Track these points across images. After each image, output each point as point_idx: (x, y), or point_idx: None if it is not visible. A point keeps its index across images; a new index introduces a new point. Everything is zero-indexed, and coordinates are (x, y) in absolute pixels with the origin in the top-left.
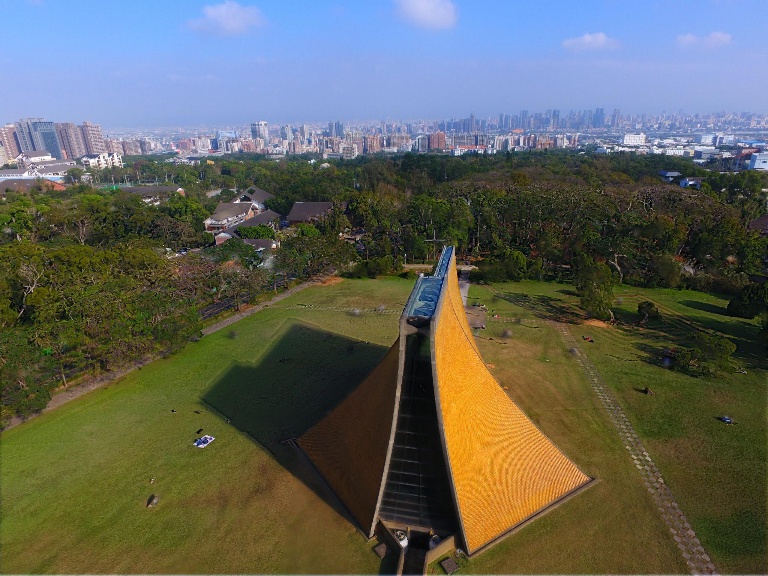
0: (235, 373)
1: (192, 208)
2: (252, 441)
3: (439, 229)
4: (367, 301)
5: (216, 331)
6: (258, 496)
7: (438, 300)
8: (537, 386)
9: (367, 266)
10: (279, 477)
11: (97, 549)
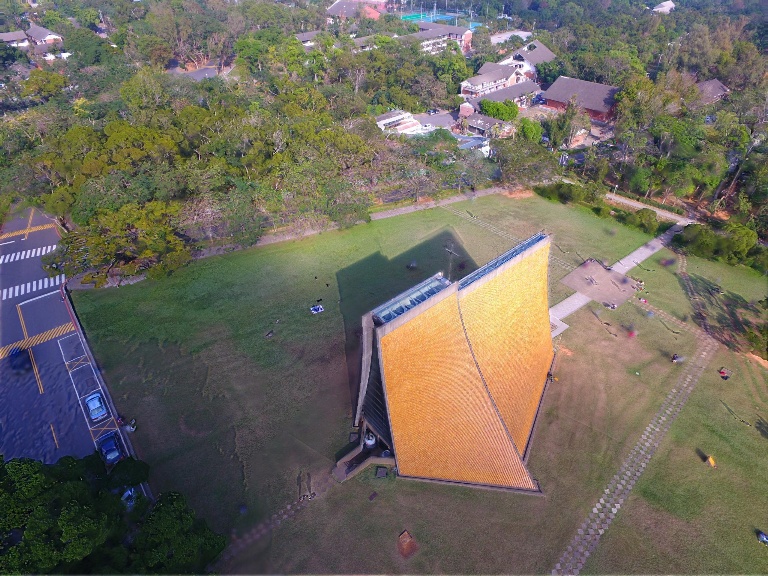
0: (371, 263)
1: (455, 67)
2: (341, 324)
3: (673, 167)
4: (529, 231)
5: (387, 217)
6: (319, 363)
7: (410, 309)
8: (589, 393)
9: (559, 190)
10: (338, 357)
11: (233, 347)
